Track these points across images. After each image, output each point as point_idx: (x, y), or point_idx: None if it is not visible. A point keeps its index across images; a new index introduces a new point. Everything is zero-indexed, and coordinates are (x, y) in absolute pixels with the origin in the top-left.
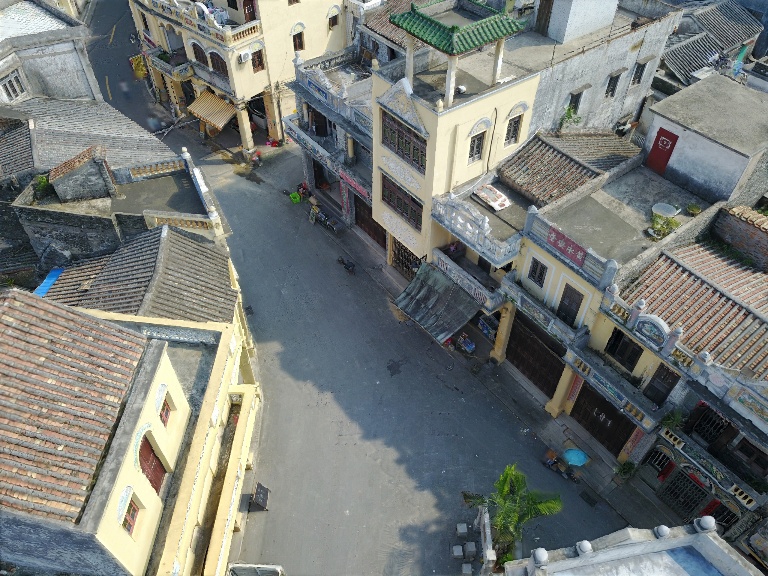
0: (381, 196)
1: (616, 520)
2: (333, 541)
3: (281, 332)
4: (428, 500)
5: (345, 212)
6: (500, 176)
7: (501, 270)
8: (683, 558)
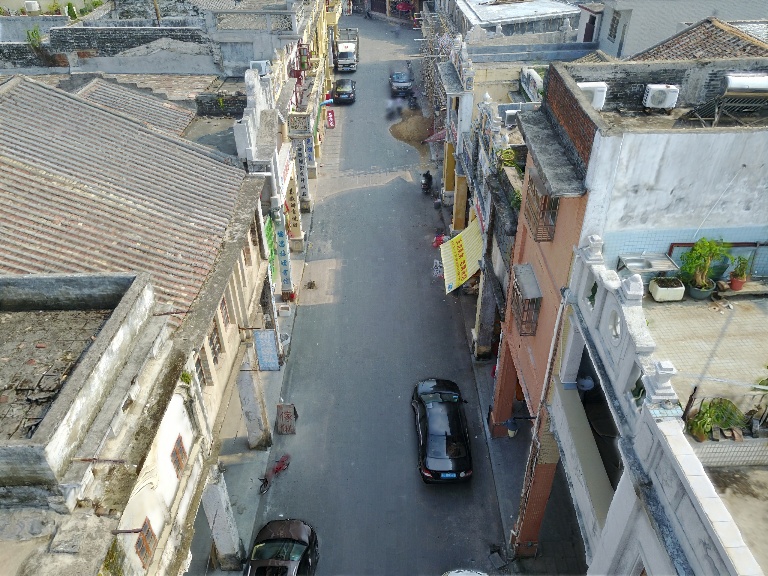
0: None
1: None
2: None
3: None
4: None
5: (366, 4)
6: None
7: None
8: None
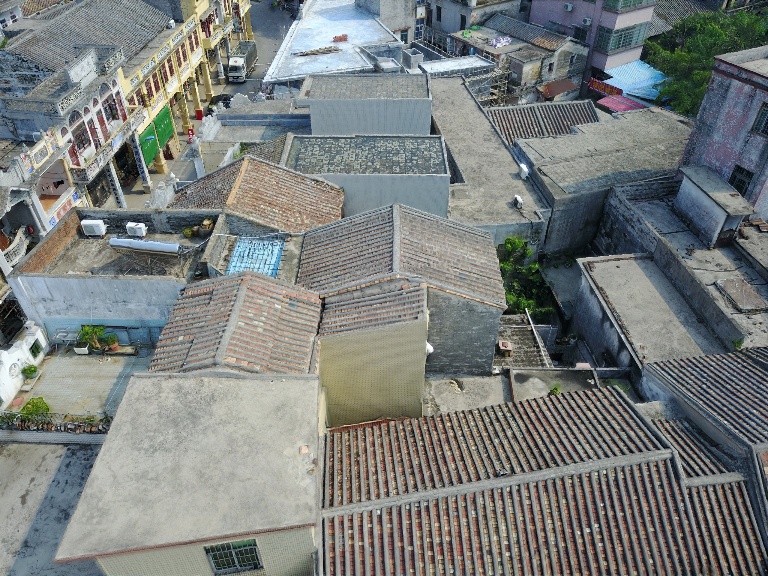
0: None
1: None
2: None
3: None
4: None
5: (295, 2)
6: None
7: None
8: None
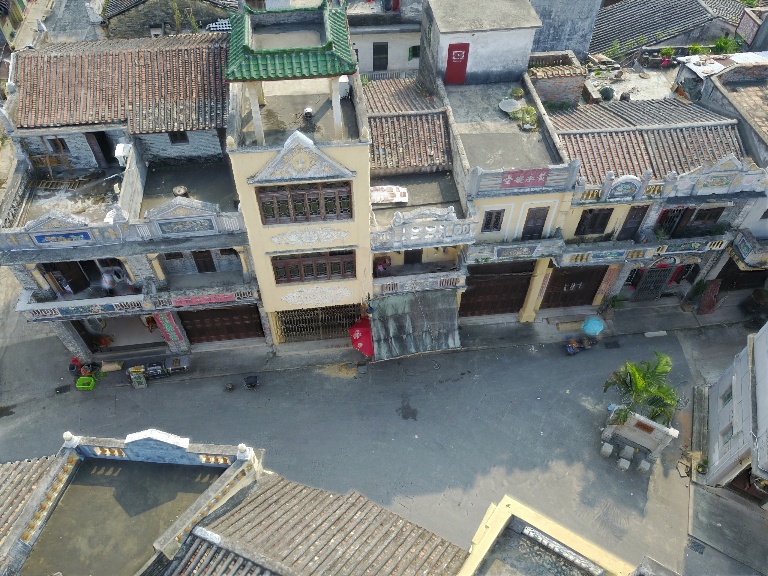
0: (274, 281)
1: (636, 339)
2: None
3: None
4: (564, 462)
5: (175, 342)
6: None
7: (438, 249)
8: None
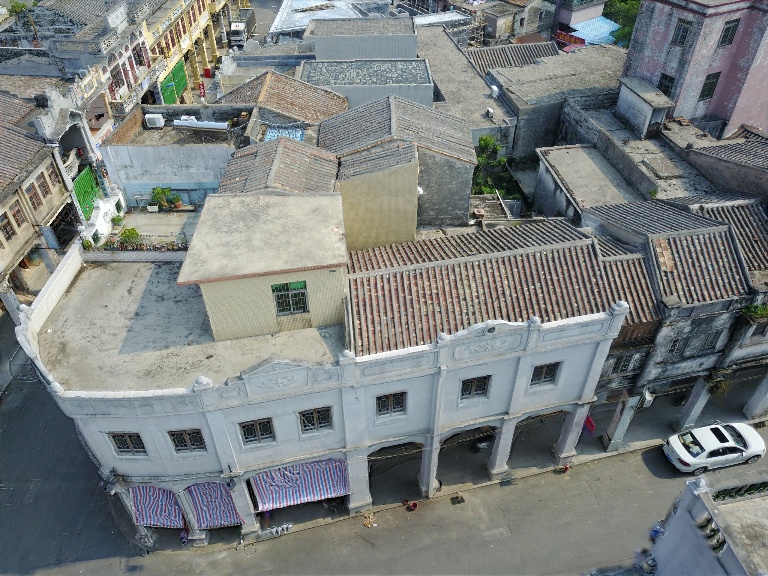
0: None
1: None
2: None
3: (259, 1)
4: None
5: None
6: None
7: None
8: None
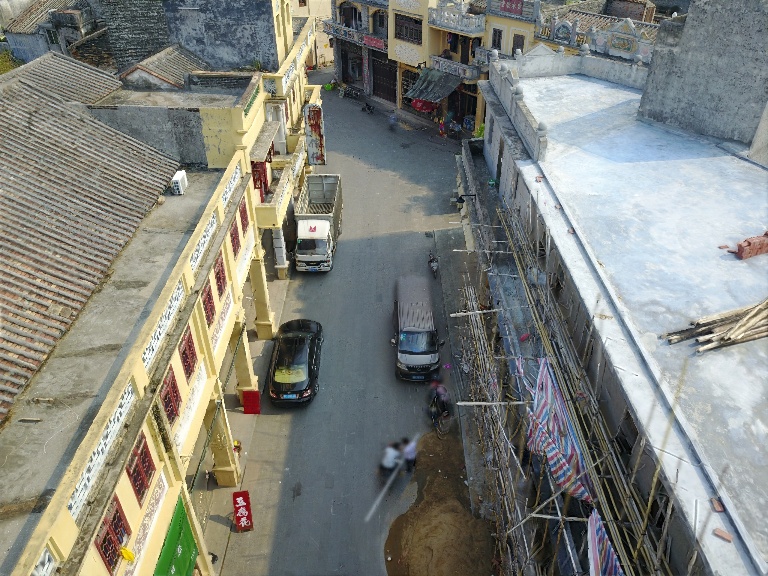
0: (394, 35)
1: None
2: (369, 202)
3: None
4: (432, 188)
5: (366, 85)
6: (472, 8)
7: None
8: (575, 76)
